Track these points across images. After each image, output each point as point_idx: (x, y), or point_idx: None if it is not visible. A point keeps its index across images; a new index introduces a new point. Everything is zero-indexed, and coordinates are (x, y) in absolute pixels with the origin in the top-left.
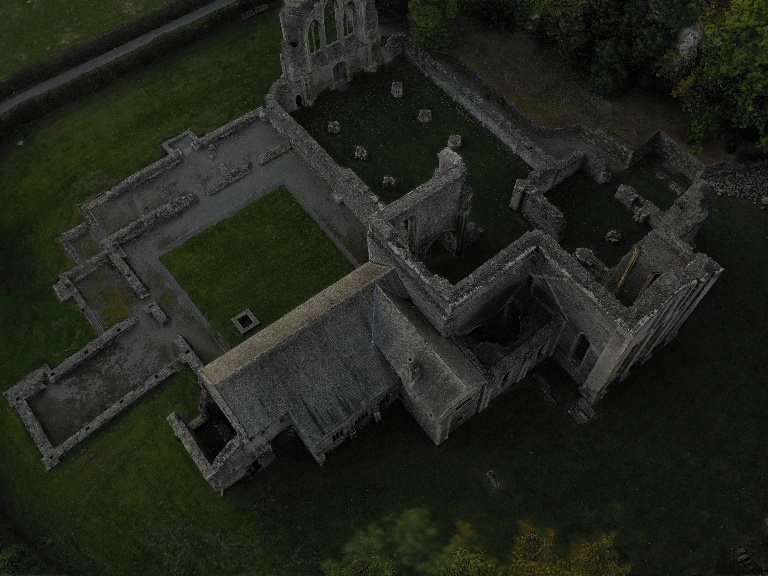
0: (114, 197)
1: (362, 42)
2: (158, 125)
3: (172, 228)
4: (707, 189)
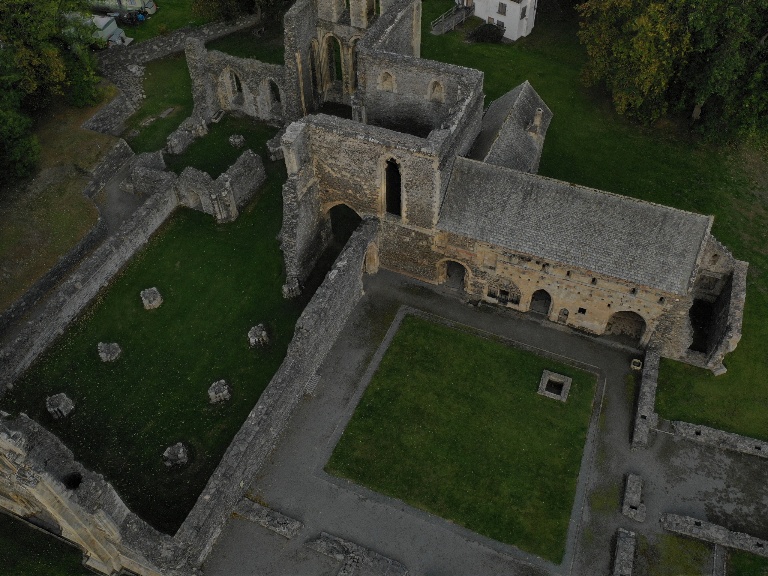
0: None
1: None
2: None
3: None
4: None
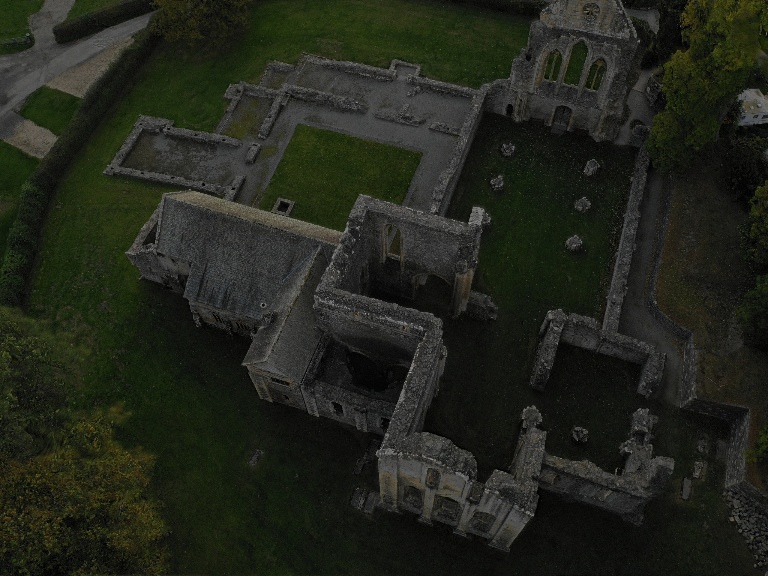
0: (328, 66)
1: (599, 105)
2: (408, 46)
3: (329, 115)
4: (668, 474)
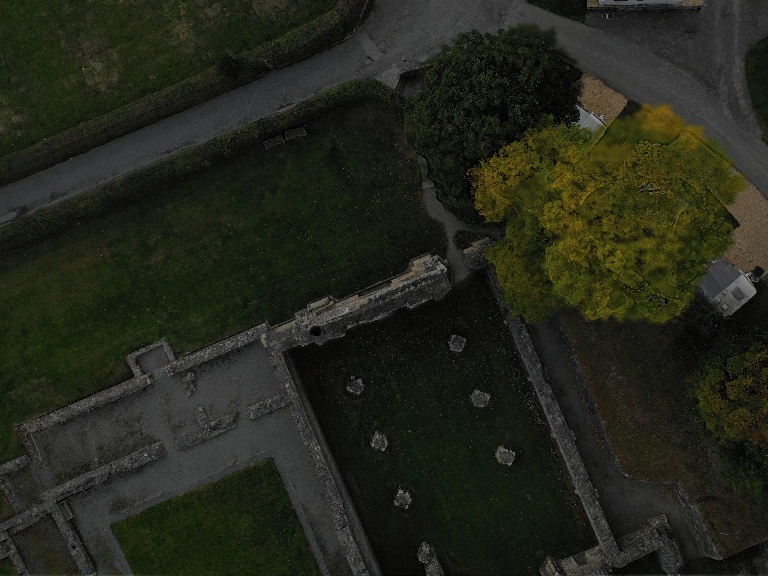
0: (62, 421)
1: None
2: (124, 322)
3: (129, 487)
4: None
